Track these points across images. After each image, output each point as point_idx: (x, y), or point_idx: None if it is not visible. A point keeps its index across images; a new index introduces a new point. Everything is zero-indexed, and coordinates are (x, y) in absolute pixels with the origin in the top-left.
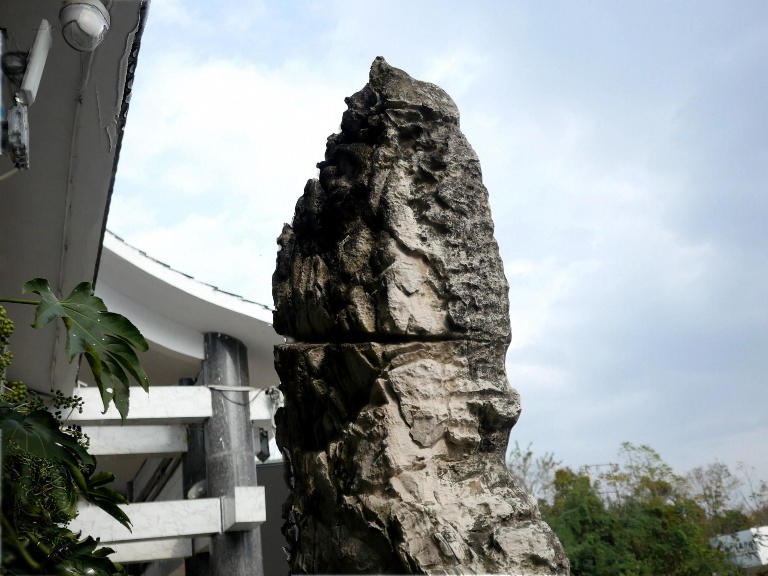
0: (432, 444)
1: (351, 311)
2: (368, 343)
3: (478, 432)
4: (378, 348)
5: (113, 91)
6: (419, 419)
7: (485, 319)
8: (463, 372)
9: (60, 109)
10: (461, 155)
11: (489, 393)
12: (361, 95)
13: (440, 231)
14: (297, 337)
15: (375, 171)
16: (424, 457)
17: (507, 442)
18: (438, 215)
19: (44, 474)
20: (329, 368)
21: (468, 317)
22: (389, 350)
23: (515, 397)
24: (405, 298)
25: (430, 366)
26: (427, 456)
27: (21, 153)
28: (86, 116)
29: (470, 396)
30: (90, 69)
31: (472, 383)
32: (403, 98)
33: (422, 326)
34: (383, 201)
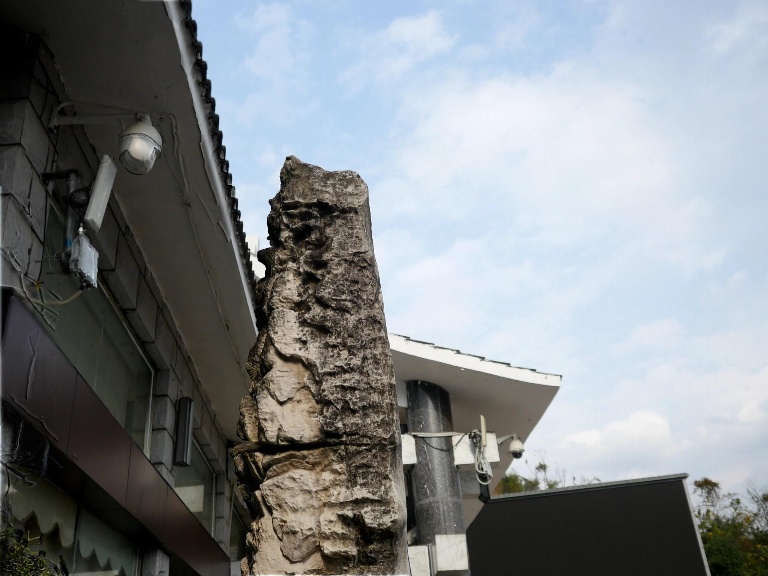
0: (304, 558)
1: (241, 421)
2: (253, 453)
3: (356, 544)
4: (260, 458)
5: (209, 192)
6: (286, 533)
7: (361, 422)
8: (340, 480)
9: (173, 215)
10: (345, 249)
11: (364, 502)
12: None
13: (323, 332)
14: None
15: (272, 275)
16: (294, 573)
17: (392, 553)
18: (317, 316)
19: (37, 575)
20: None
21: (340, 422)
22: (264, 461)
23: (392, 505)
24: (278, 407)
25: (299, 477)
26: (298, 571)
27: (81, 276)
28: (198, 216)
29: (342, 506)
30: (186, 177)
31: (345, 492)
32: (297, 198)
33: (291, 436)
34: (269, 307)
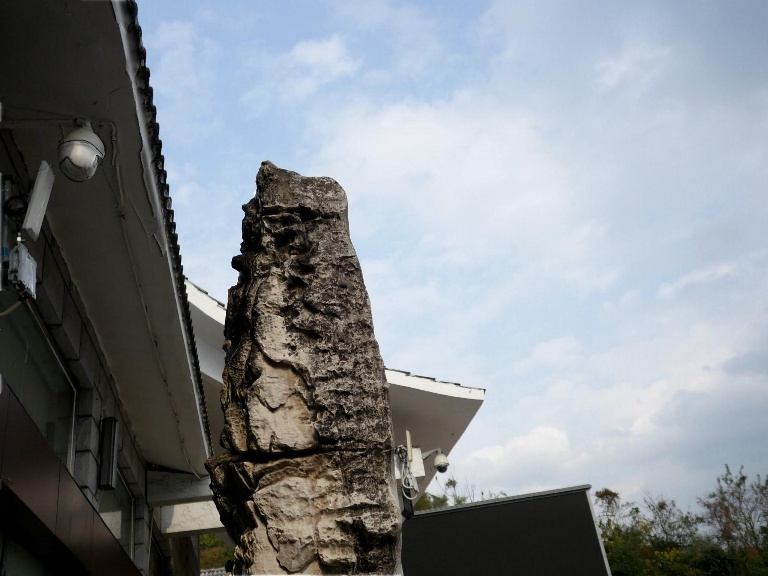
0: (302, 568)
1: (227, 430)
2: (242, 463)
3: (355, 551)
4: (250, 468)
5: (146, 203)
6: (283, 543)
7: (356, 427)
8: (336, 486)
9: (106, 227)
10: (332, 254)
11: (362, 507)
12: (254, 202)
13: (312, 337)
14: (226, 448)
15: (254, 281)
16: None
17: (391, 558)
18: (306, 321)
19: None
20: (228, 486)
21: (335, 427)
22: (256, 470)
23: (391, 509)
24: (269, 414)
25: (294, 485)
26: None
27: (21, 288)
28: (132, 228)
29: (340, 513)
30: (121, 188)
31: (343, 498)
32: (278, 202)
33: (285, 443)
34: (254, 313)
